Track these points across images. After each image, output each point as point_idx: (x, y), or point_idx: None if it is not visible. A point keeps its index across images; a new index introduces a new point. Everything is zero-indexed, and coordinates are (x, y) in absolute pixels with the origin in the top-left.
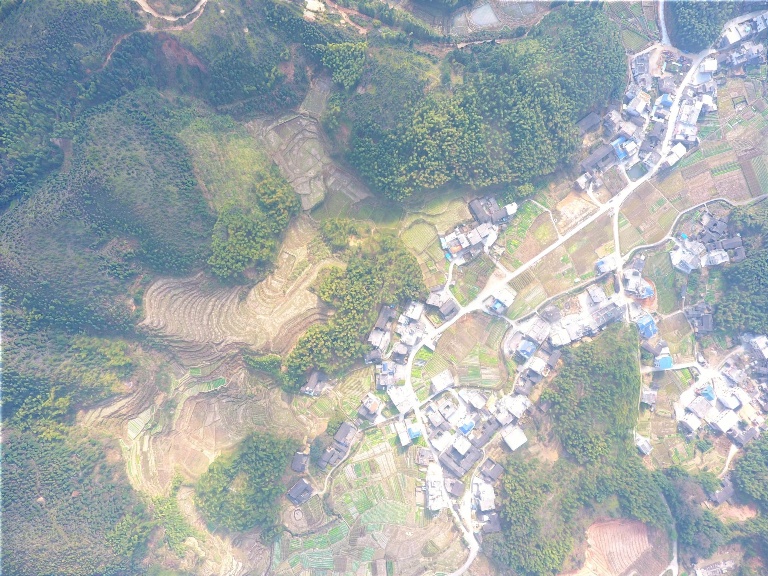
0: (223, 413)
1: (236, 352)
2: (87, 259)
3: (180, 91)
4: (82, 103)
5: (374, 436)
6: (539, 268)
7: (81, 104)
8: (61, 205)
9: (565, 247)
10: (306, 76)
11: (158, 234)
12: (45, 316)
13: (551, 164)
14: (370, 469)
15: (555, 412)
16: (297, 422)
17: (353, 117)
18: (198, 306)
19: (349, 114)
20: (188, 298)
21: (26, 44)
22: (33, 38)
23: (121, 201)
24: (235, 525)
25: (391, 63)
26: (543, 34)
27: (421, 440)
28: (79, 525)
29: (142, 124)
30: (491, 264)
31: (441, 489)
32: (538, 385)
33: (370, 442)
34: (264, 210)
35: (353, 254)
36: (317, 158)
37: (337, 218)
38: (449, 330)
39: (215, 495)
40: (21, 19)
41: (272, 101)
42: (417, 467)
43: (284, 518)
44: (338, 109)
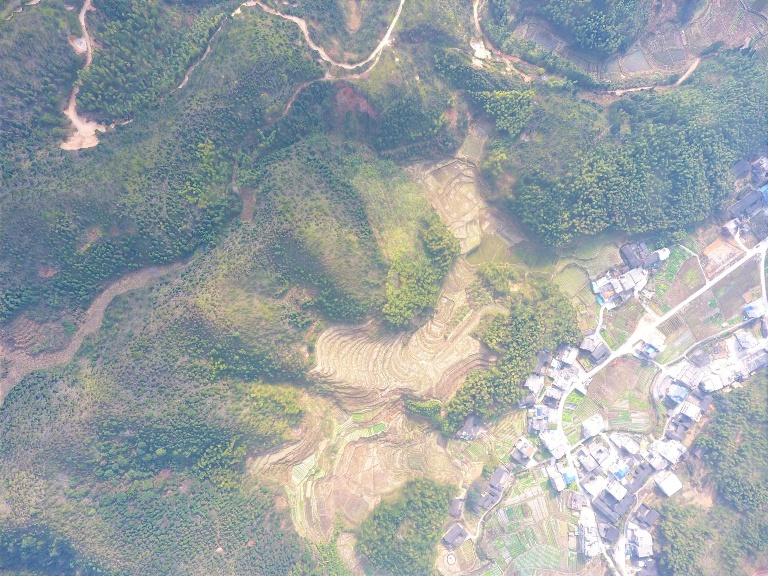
0: (381, 458)
1: (398, 397)
2: (271, 309)
3: (345, 136)
4: (259, 150)
5: (526, 480)
6: (687, 312)
7: (258, 151)
8: (253, 256)
9: (712, 292)
10: None
11: (342, 284)
12: (228, 366)
13: (705, 211)
14: (522, 513)
15: (713, 459)
16: (453, 466)
17: (519, 164)
18: (364, 352)
19: (514, 161)
20: (356, 344)
21: (217, 94)
22: (224, 88)
23: (311, 252)
24: (402, 573)
25: (559, 112)
26: (705, 84)
27: (573, 484)
28: (255, 575)
29: (320, 172)
30: (640, 308)
31: (597, 535)
32: (690, 430)
33: (522, 486)
34: (429, 256)
35: (516, 300)
36: (473, 202)
37: (496, 263)
38: (599, 374)
39: (382, 543)
40: (212, 69)
41: (434, 146)
42: (569, 511)
43: (438, 563)
44: (505, 157)
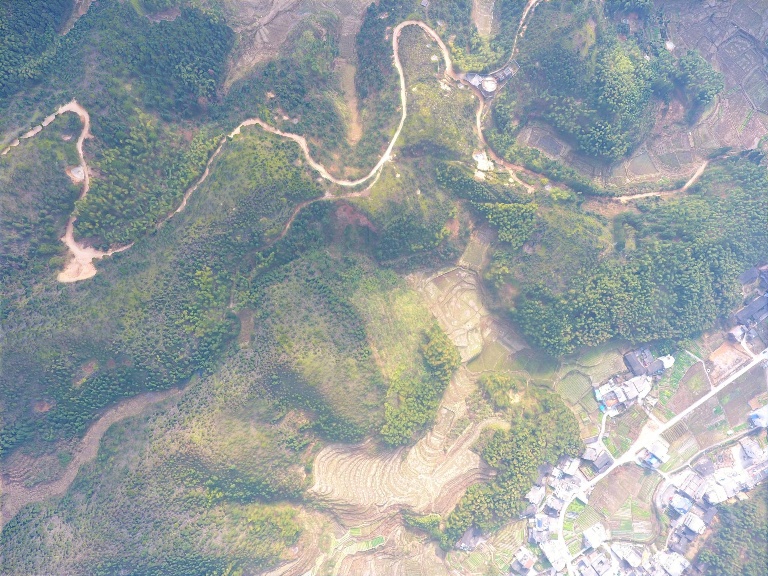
0: (379, 570)
1: (397, 512)
2: (268, 436)
3: (345, 247)
4: (257, 269)
5: None
6: (692, 419)
7: (256, 270)
8: (250, 387)
9: (718, 398)
10: (469, 231)
11: (340, 411)
12: (225, 493)
13: (711, 320)
14: None
15: None
16: None
17: (521, 278)
18: (363, 468)
19: (516, 274)
20: (354, 461)
21: (216, 222)
22: (223, 216)
23: (309, 382)
24: None
25: (562, 226)
26: (712, 195)
27: None
28: None
29: (319, 293)
30: (644, 415)
31: None
32: (694, 543)
33: None
34: (429, 370)
35: (517, 415)
36: (475, 310)
37: (497, 374)
38: (601, 482)
39: None
40: (210, 196)
41: (435, 256)
42: None
43: None
44: (507, 270)
